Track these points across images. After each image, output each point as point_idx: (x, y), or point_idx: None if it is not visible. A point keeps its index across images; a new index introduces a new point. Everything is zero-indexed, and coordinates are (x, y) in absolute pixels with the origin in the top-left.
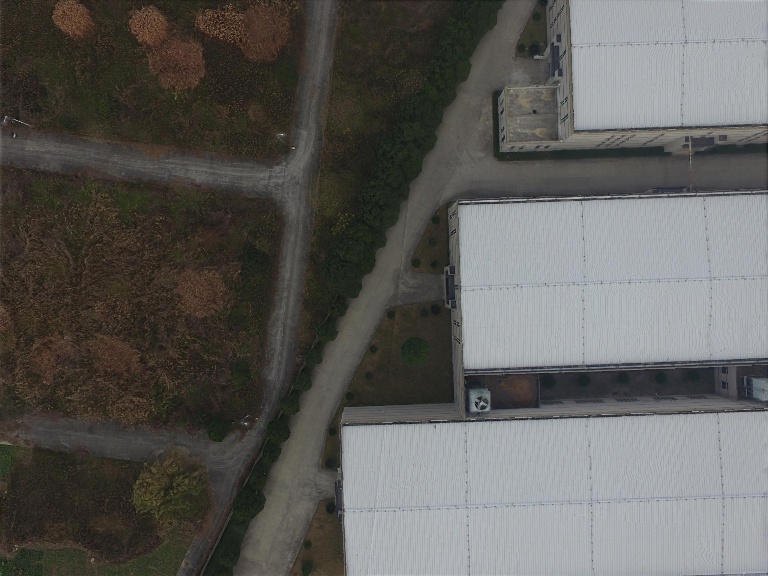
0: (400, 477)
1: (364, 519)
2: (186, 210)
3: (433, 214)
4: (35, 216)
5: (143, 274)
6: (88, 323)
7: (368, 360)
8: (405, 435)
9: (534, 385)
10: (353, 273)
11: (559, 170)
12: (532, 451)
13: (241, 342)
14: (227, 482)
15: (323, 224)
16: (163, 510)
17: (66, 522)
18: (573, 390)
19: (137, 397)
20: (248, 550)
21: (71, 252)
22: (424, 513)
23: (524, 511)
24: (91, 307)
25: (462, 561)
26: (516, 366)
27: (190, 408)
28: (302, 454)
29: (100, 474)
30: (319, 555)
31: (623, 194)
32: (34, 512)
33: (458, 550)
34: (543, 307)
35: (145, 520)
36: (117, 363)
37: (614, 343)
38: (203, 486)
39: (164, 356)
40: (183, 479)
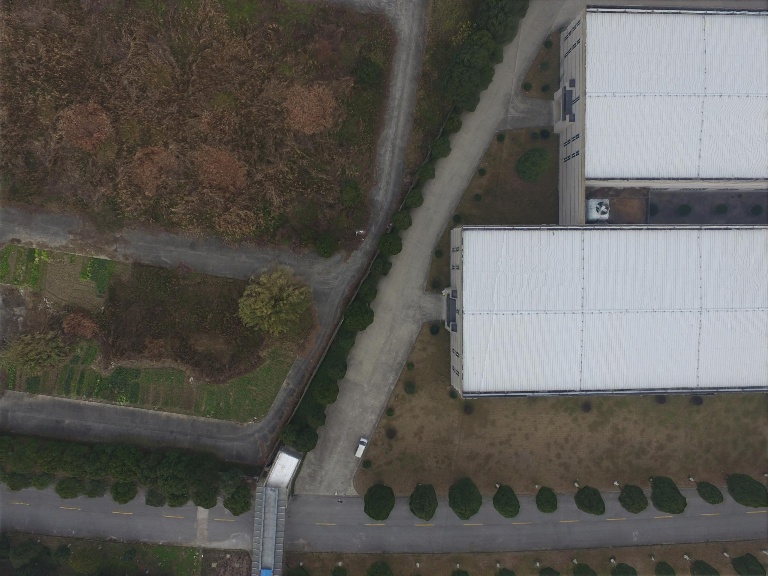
0: (516, 285)
1: (482, 322)
2: (297, 22)
3: (545, 39)
4: (140, 18)
5: (253, 84)
6: (193, 135)
7: (476, 183)
8: (524, 241)
9: (644, 204)
10: (477, 78)
11: (669, 1)
12: (646, 260)
13: (351, 159)
14: (331, 302)
15: (439, 39)
16: (274, 318)
17: (166, 339)
18: (673, 221)
19: (244, 210)
20: (350, 371)
21: (177, 59)
22: (541, 317)
23: (637, 318)
24: (198, 116)
25: (574, 366)
26: (634, 176)
27: (295, 227)
28: (407, 276)
29: (201, 292)
30: (421, 377)
31: (745, 8)
32: (132, 328)
33: (571, 355)
34: (664, 117)
35: (247, 338)
36: (222, 177)
37: (729, 157)
38: (308, 304)
39: (273, 169)
40: (293, 290)
